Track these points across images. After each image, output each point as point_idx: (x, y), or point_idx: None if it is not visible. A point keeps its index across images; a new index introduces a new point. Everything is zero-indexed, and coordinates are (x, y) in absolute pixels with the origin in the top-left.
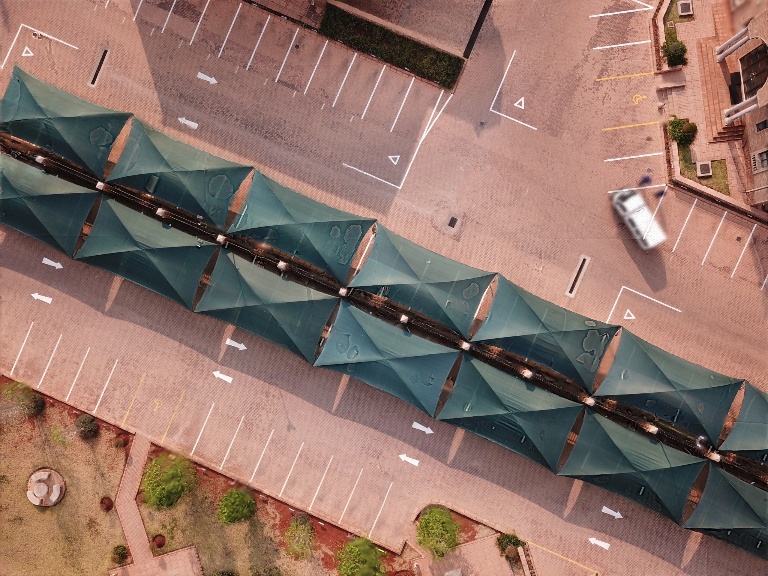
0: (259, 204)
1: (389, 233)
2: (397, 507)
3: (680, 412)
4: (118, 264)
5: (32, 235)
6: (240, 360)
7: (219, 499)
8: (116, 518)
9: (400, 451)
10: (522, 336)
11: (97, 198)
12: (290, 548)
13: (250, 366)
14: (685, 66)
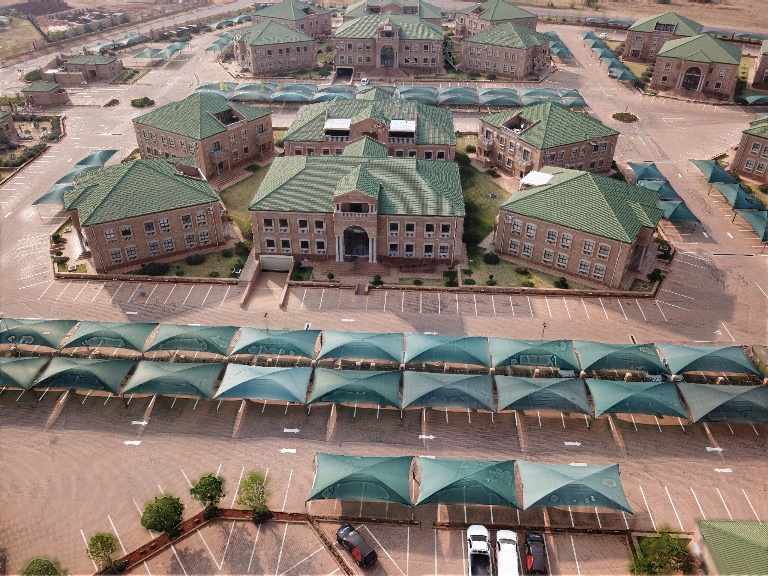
0: None
1: None
2: None
3: None
4: None
5: None
6: None
7: None
8: None
9: None
10: None
11: None
12: None
13: None
14: (65, 244)
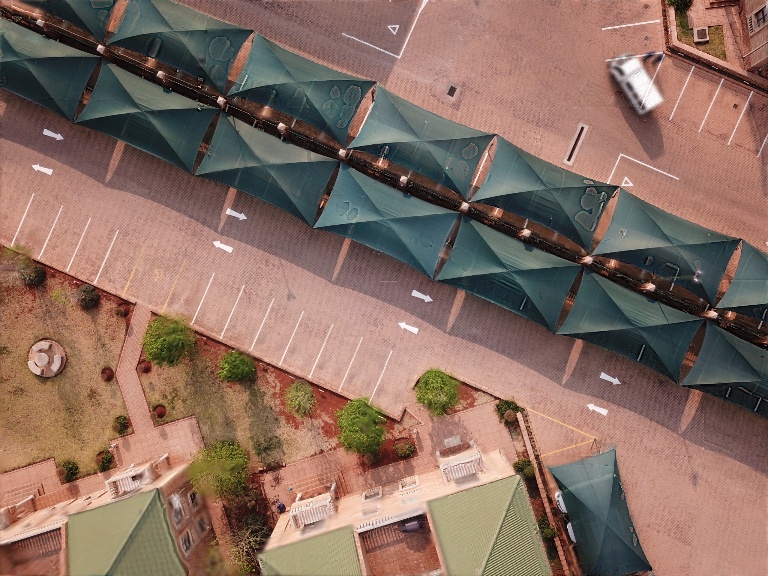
0: (259, 65)
1: (388, 94)
2: (397, 375)
3: (677, 278)
4: (119, 129)
5: (33, 99)
6: (240, 230)
7: (219, 367)
8: (117, 388)
9: (400, 319)
10: (521, 193)
11: (98, 62)
12: (290, 417)
13: (250, 236)
14: None
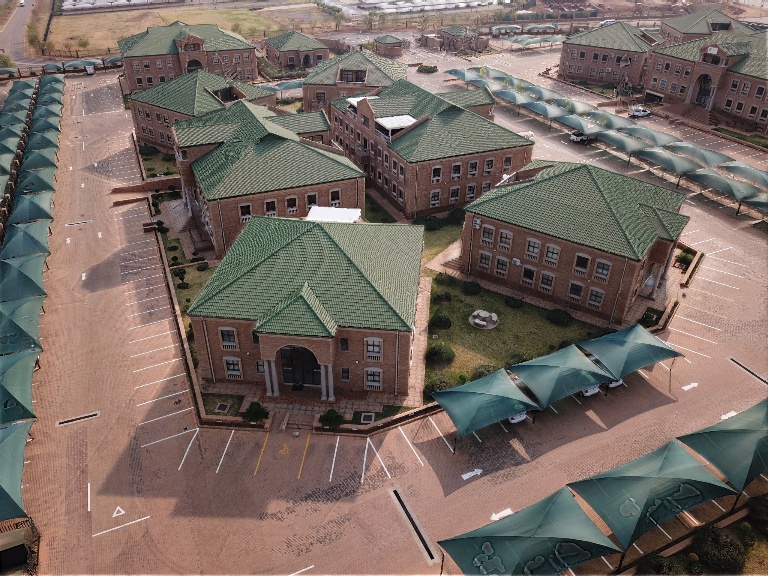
0: None
1: None
2: None
3: None
4: None
5: None
6: None
7: None
8: None
9: None
10: None
11: None
12: None
13: None
14: None
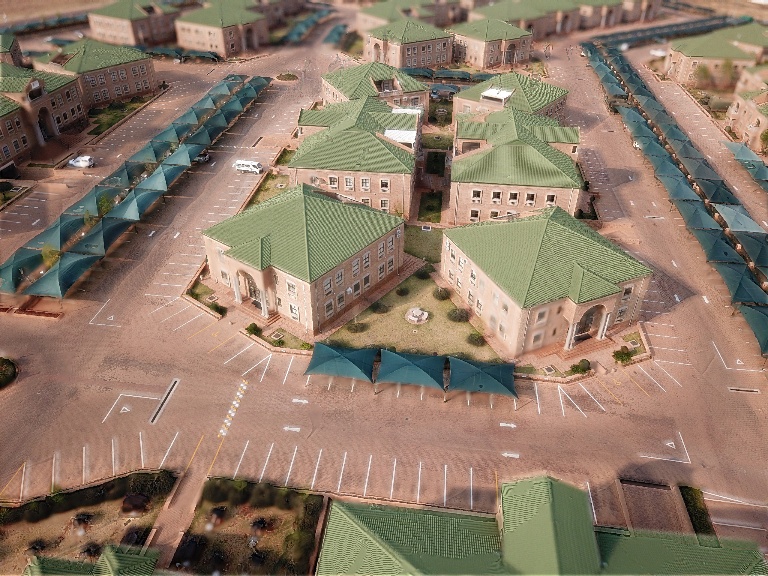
0: None
1: None
2: None
3: None
4: None
5: None
6: None
7: None
8: None
9: None
10: None
11: None
12: None
13: None
14: None
